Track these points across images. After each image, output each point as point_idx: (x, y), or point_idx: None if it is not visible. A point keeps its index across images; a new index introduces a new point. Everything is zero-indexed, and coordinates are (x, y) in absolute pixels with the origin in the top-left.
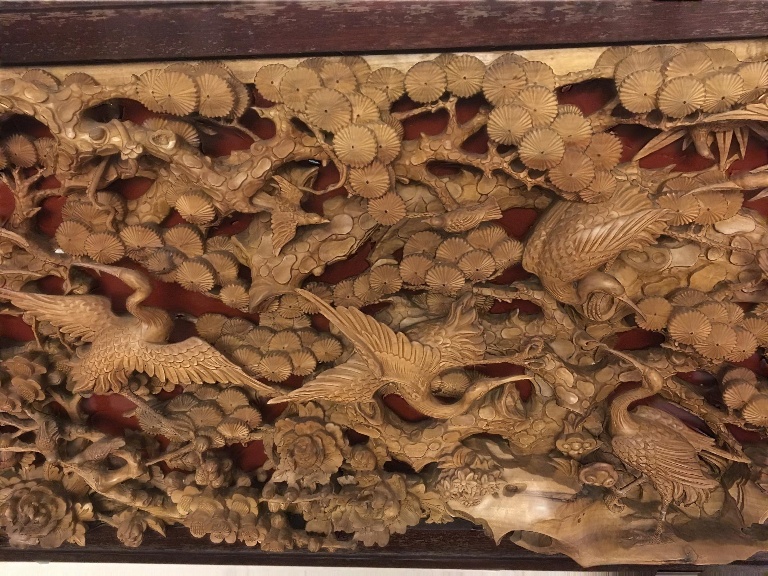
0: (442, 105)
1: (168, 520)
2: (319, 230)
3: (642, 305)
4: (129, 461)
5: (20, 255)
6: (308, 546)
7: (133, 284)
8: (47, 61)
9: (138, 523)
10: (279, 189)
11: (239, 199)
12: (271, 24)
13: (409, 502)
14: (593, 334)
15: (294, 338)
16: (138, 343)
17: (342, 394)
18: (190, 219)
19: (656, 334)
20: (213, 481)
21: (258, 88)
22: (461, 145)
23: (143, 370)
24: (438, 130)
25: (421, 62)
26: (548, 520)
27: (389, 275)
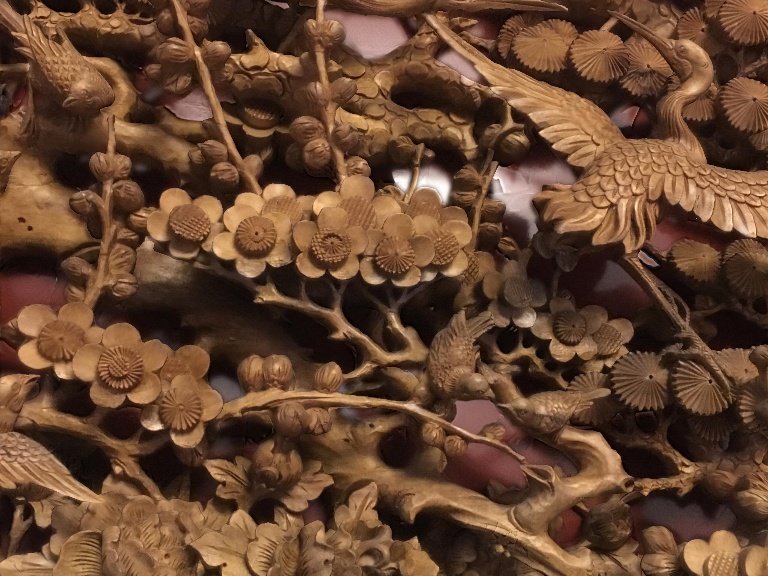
0: None
1: None
2: None
3: None
4: (602, 448)
5: None
6: None
7: (698, 56)
8: None
9: None
10: None
11: None
12: None
13: None
14: None
15: None
16: (686, 160)
17: None
18: (743, 27)
19: None
20: None
21: None
22: None
23: (693, 206)
24: None
25: None
26: None
27: None
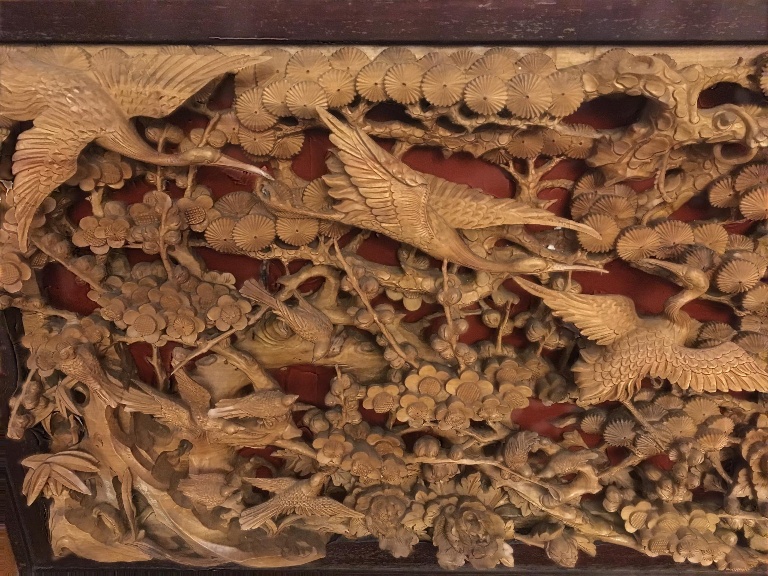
0: None
1: (591, 538)
2: None
3: None
4: (590, 475)
5: (498, 251)
6: None
7: (699, 283)
8: (640, 40)
9: (570, 541)
10: None
11: None
12: None
13: None
14: None
15: None
16: (671, 347)
17: None
18: (756, 215)
19: None
20: (676, 496)
21: None
22: None
23: (667, 376)
24: None
25: None
26: None
27: None
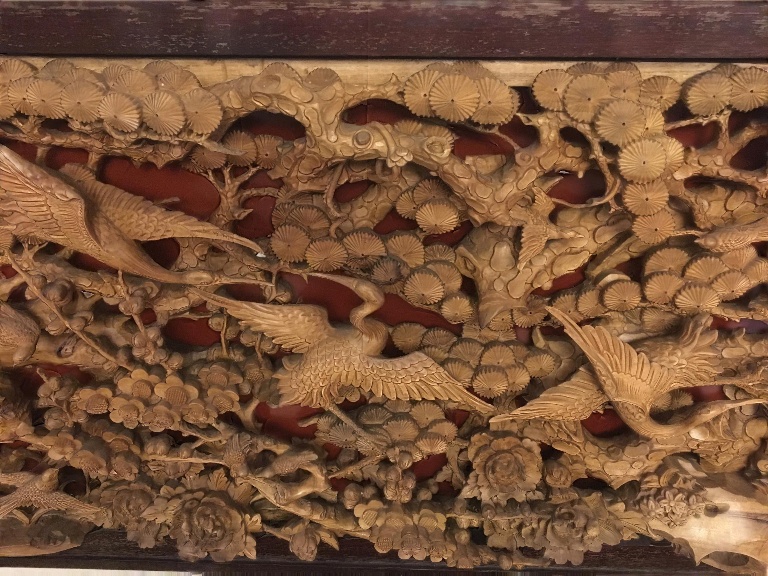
0: (715, 118)
1: (339, 532)
2: (557, 243)
3: None
4: (316, 474)
5: (214, 257)
6: (501, 564)
7: (369, 297)
8: (295, 55)
9: (312, 536)
10: (530, 200)
11: (502, 212)
12: (551, 25)
13: (608, 521)
14: None
15: (509, 353)
16: (359, 357)
17: (564, 413)
18: (430, 229)
19: None
20: (402, 496)
21: (536, 94)
22: (730, 161)
23: (359, 385)
24: (702, 143)
25: (708, 73)
26: (753, 542)
27: (629, 292)
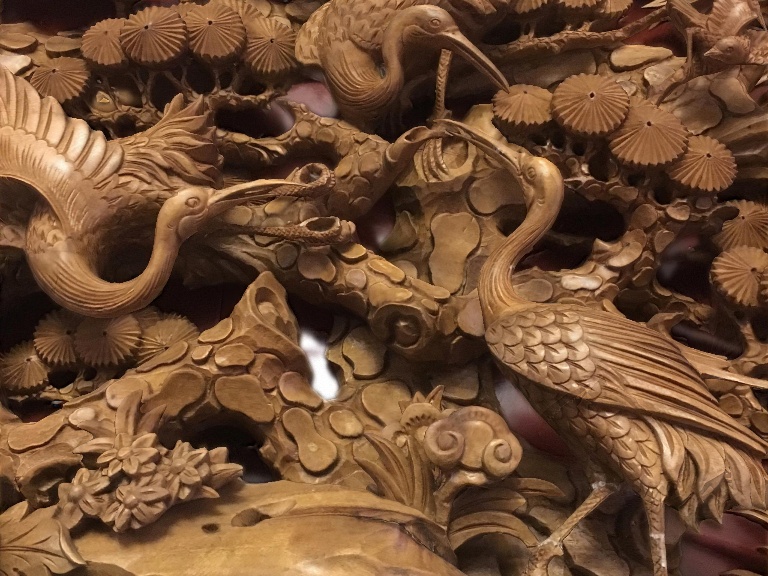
0: None
1: None
2: None
3: (502, 93)
4: None
5: None
6: None
7: None
8: None
9: None
10: None
11: None
12: None
13: None
14: (447, 245)
15: None
16: None
17: None
18: None
19: (568, 253)
20: None
21: None
22: None
23: None
24: None
25: None
26: (341, 558)
27: (65, 64)
